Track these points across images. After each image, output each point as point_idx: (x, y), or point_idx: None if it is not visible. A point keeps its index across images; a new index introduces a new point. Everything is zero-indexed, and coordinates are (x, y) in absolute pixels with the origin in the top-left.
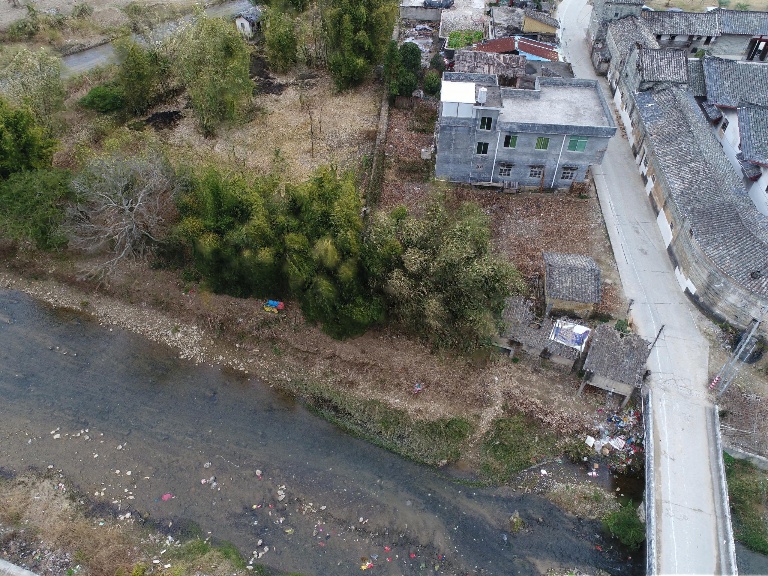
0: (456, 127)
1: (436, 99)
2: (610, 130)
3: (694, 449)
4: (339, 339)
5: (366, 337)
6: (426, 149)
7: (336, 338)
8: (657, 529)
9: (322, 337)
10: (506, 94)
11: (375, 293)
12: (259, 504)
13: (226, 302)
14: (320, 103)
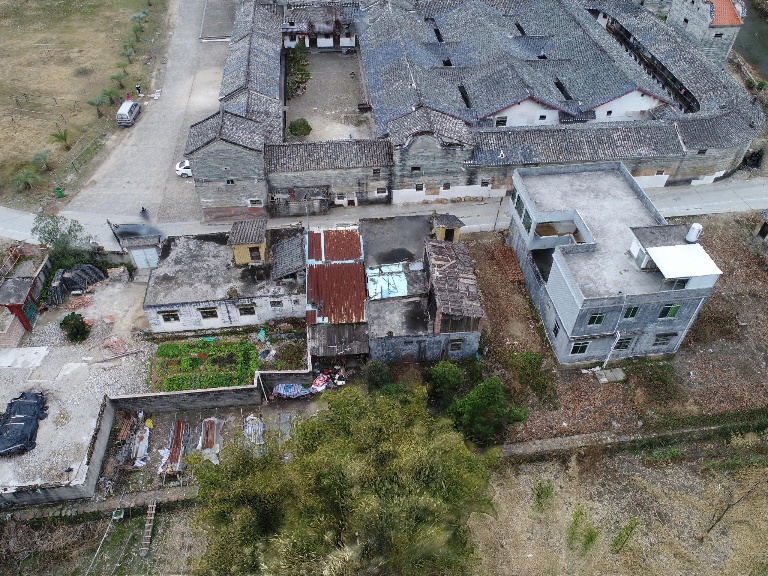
0: None
1: (482, 370)
2: None
3: None
4: None
5: None
6: (602, 375)
7: None
8: None
9: None
10: None
11: None
12: None
13: None
14: None
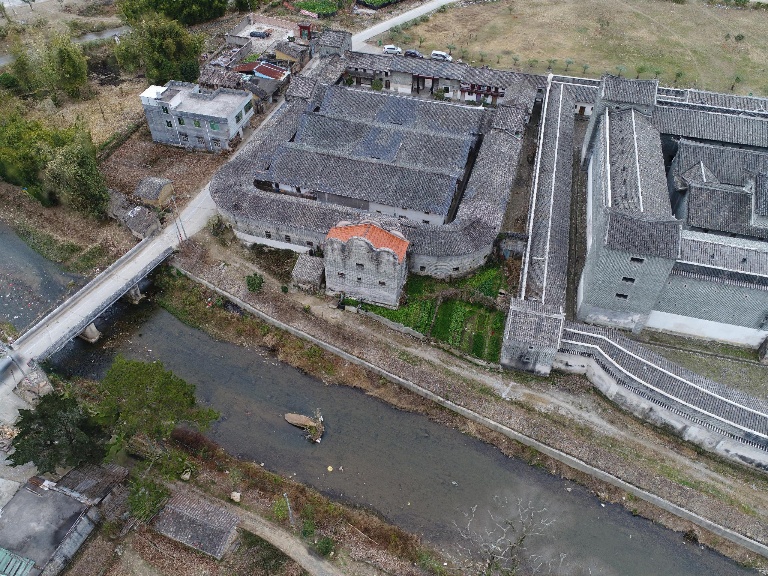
0: (152, 111)
1: None
2: (224, 119)
3: (149, 261)
4: (44, 206)
5: (60, 208)
6: None
7: None
8: (102, 282)
9: (41, 206)
10: (195, 95)
11: (47, 181)
12: None
13: (9, 187)
14: (136, 93)
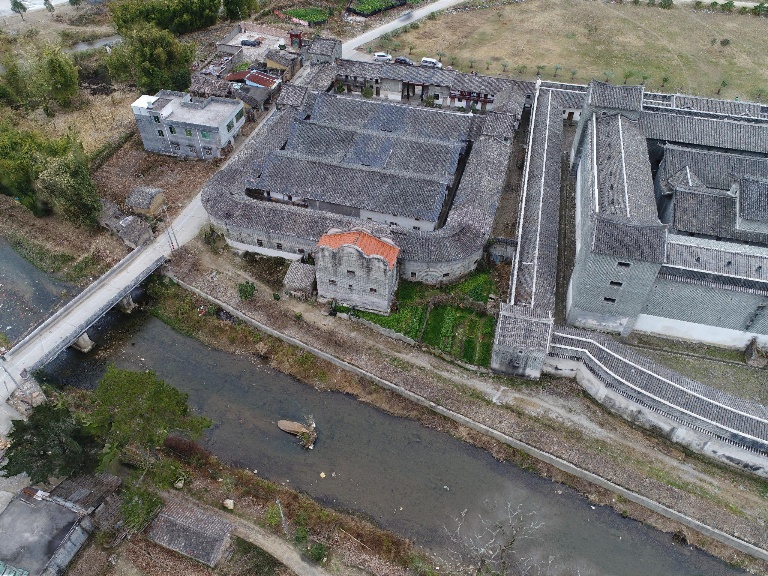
0: (143, 120)
1: None
2: (216, 128)
3: (141, 270)
4: (36, 216)
5: (52, 218)
6: None
7: (35, 216)
8: (95, 292)
9: (33, 216)
10: (186, 105)
11: (39, 191)
12: None
13: (1, 197)
14: (128, 102)
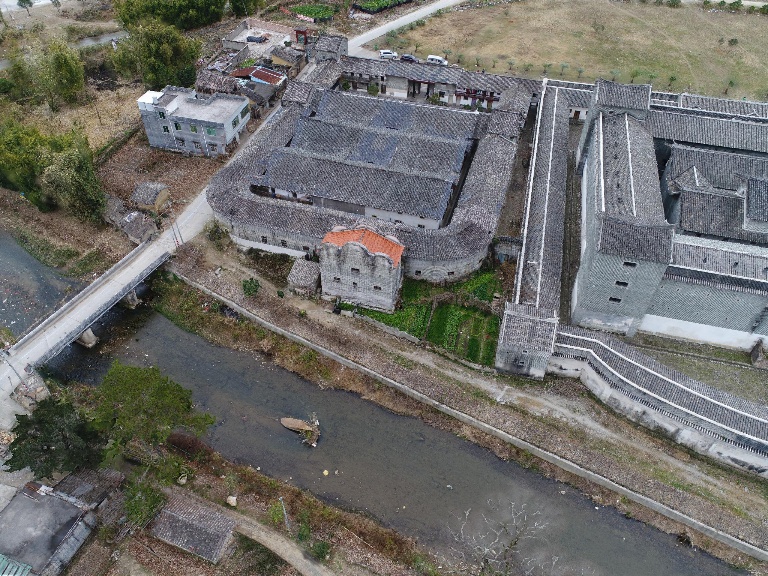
0: (148, 116)
1: None
2: (221, 124)
3: (145, 266)
4: (41, 211)
5: (57, 213)
6: None
7: None
8: (99, 287)
9: (38, 211)
10: (191, 101)
11: None
12: None
13: (6, 192)
14: (133, 98)
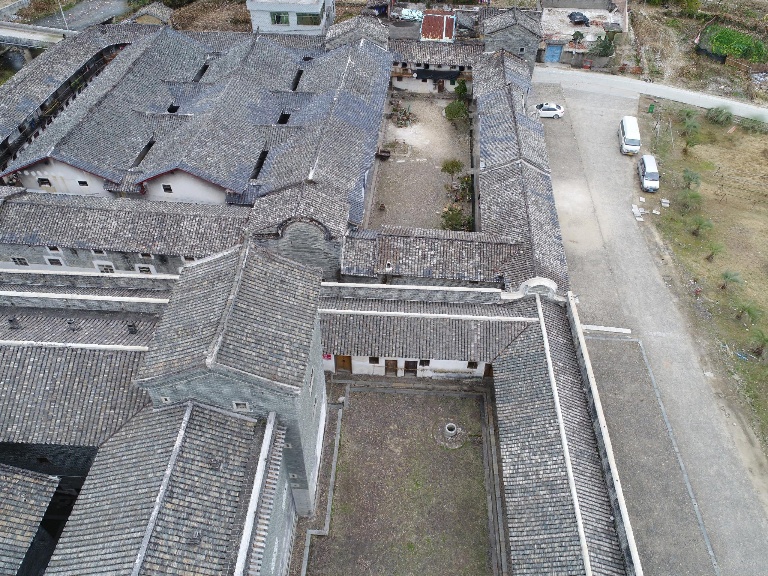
0: None
1: None
2: None
3: None
4: None
5: None
6: None
7: None
8: None
9: None
10: None
11: None
12: (106, 0)
13: None
14: None
